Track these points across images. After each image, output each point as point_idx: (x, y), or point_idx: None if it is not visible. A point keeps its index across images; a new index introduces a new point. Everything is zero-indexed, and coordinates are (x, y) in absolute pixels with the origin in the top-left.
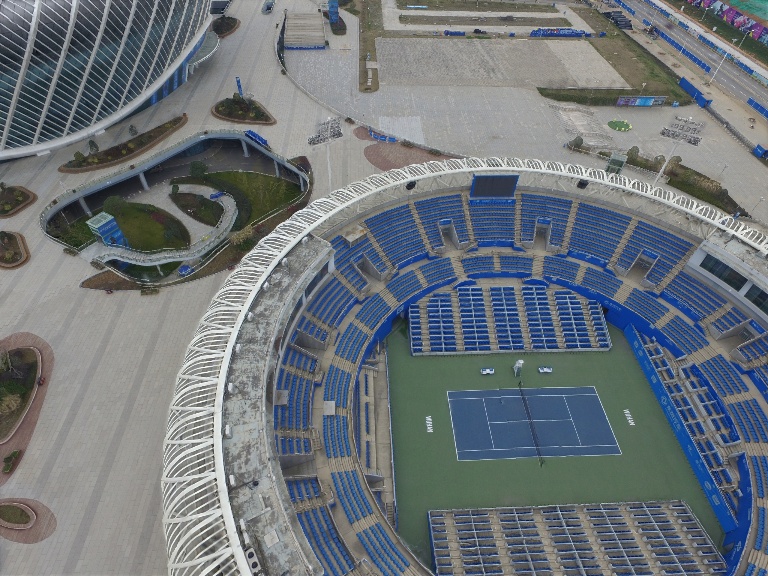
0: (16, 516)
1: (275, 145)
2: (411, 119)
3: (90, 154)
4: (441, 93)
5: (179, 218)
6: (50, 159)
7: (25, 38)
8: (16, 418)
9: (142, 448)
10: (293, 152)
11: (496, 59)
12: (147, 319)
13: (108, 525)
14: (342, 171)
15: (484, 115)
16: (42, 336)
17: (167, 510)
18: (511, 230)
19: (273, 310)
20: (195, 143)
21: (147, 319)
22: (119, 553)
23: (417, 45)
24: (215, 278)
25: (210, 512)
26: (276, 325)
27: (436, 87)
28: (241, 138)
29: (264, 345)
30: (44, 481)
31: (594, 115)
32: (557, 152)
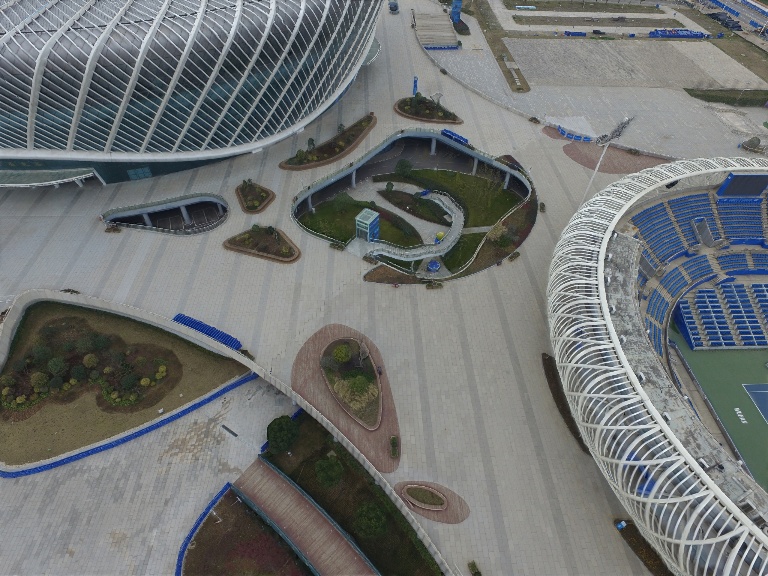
0: (429, 498)
1: (475, 144)
2: (577, 119)
3: (307, 152)
4: (593, 93)
5: (399, 215)
6: (266, 156)
7: (287, 39)
8: (376, 405)
9: (509, 435)
10: (496, 151)
11: (630, 60)
12: (445, 312)
13: (517, 507)
14: (553, 170)
15: (645, 115)
16: (355, 328)
17: (652, 491)
18: (759, 228)
19: (626, 303)
20: (392, 141)
21: (445, 312)
22: (542, 533)
23: (546, 45)
24: (488, 273)
25: (703, 493)
26: (640, 318)
27: (585, 87)
28: (435, 137)
29: (641, 337)
30: (434, 465)
31: (746, 116)
32: (734, 152)
